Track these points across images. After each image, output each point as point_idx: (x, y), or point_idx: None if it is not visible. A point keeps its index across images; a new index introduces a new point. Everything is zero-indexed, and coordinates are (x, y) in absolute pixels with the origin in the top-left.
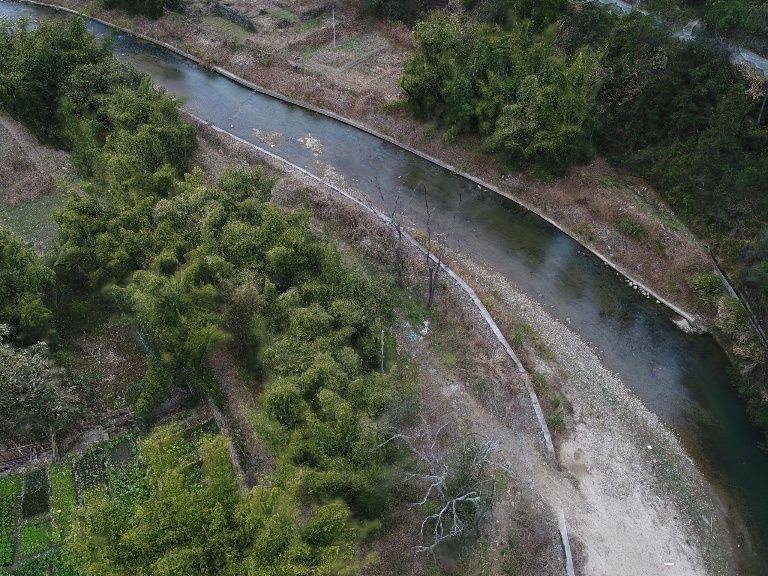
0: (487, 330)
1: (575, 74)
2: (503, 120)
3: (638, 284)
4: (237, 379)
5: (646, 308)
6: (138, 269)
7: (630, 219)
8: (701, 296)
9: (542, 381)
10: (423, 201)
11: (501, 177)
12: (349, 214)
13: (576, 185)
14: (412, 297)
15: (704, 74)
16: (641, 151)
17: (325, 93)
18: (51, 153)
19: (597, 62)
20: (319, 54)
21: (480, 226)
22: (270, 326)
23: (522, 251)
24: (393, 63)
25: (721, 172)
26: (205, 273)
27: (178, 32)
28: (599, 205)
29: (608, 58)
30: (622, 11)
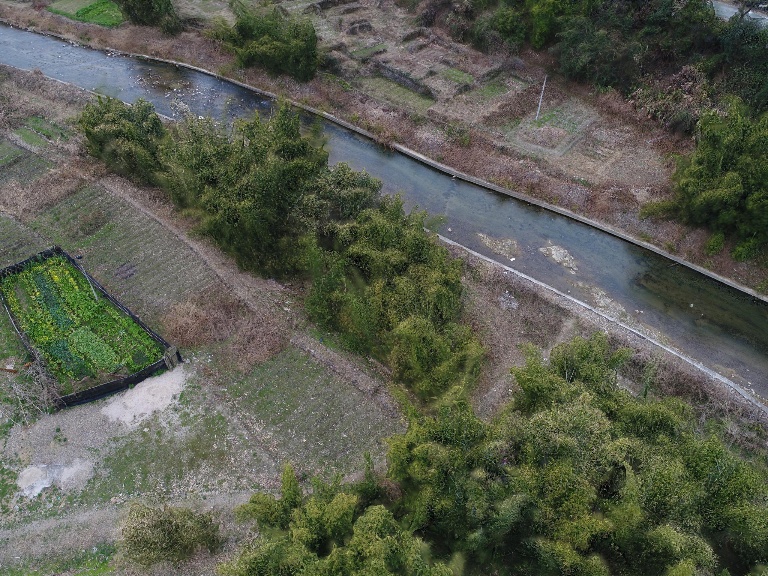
0: None
1: None
2: None
3: None
4: None
5: None
6: (527, 531)
7: None
8: None
9: None
10: (738, 343)
11: None
12: (695, 384)
13: None
14: None
15: None
16: None
17: (551, 184)
18: (260, 284)
19: None
20: (523, 129)
21: None
22: None
23: None
24: (618, 142)
25: None
26: (629, 539)
27: (339, 99)
28: None
29: None
30: None
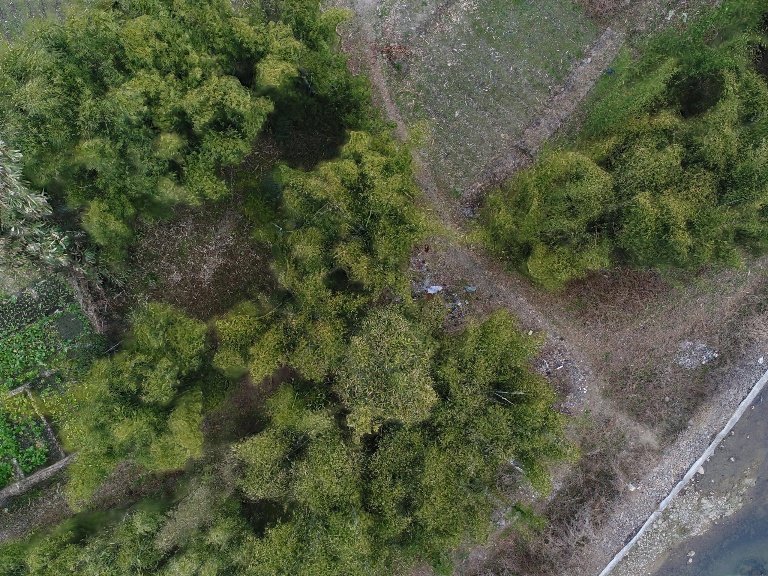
0: None
1: None
2: None
3: None
4: None
5: None
6: None
7: None
8: None
9: None
10: None
11: None
12: None
13: None
14: None
15: None
16: None
17: None
18: None
19: None
20: None
21: None
22: None
23: None
24: None
25: None
26: None
27: None
28: None
29: None
30: None
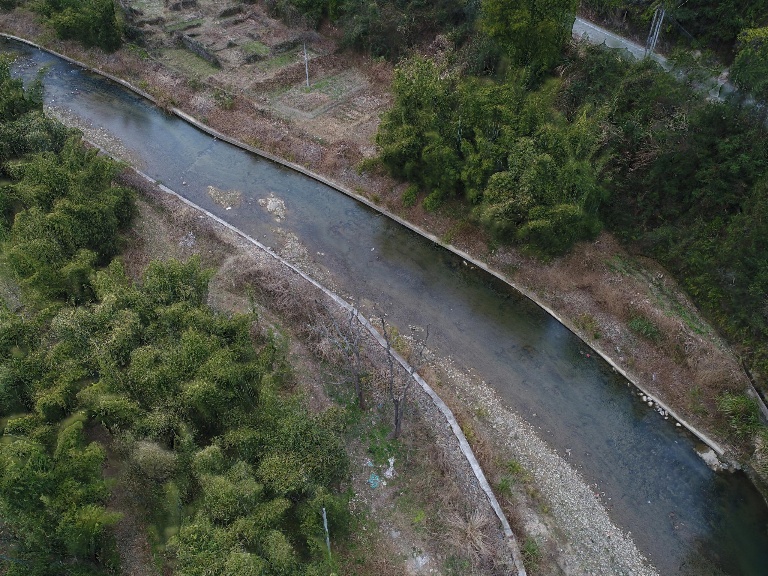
0: (467, 472)
1: (578, 137)
2: (492, 189)
3: (654, 399)
4: (144, 551)
5: (664, 433)
6: (22, 408)
7: (644, 317)
8: (733, 424)
9: (534, 552)
10: (399, 282)
11: (491, 252)
12: None
13: (579, 267)
14: (376, 422)
15: (736, 147)
16: (657, 230)
17: (293, 143)
18: None
19: (604, 119)
20: (290, 95)
21: (464, 316)
22: (181, 493)
23: (514, 351)
24: (372, 107)
25: (756, 266)
26: None
27: (135, 67)
28: (606, 296)
29: (617, 113)
30: (633, 57)
